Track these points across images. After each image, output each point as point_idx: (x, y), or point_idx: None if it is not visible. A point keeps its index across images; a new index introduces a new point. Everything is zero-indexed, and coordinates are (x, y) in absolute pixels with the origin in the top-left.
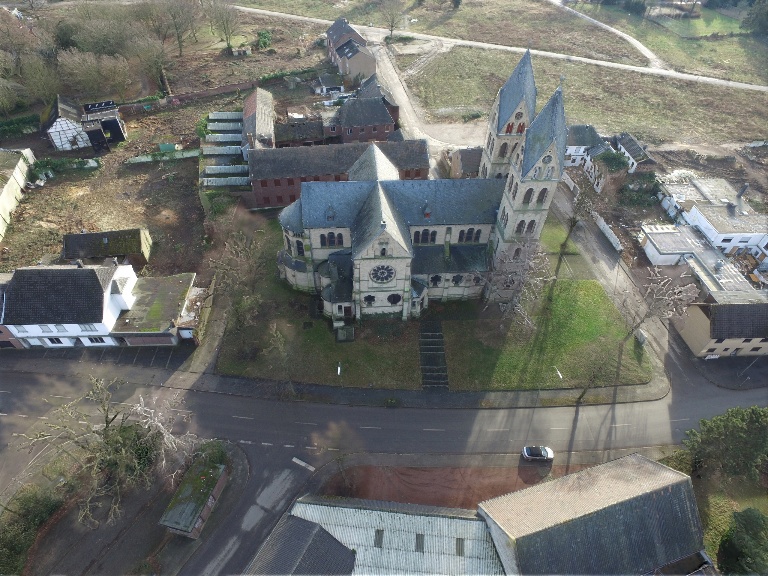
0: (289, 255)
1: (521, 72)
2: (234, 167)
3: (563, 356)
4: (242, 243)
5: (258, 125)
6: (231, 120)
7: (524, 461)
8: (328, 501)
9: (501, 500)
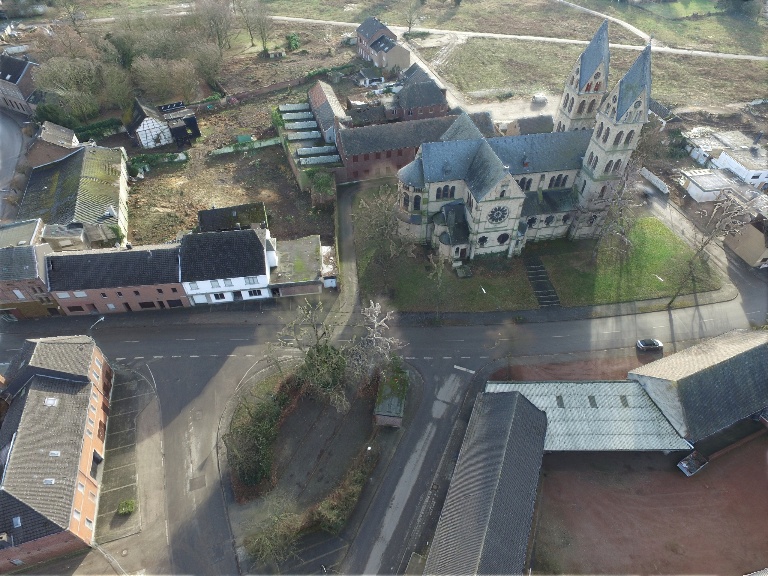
0: (404, 211)
1: (600, 38)
2: (322, 148)
3: (647, 275)
4: (385, 195)
5: (334, 111)
6: (299, 111)
7: (640, 351)
8: (510, 381)
9: (645, 367)
